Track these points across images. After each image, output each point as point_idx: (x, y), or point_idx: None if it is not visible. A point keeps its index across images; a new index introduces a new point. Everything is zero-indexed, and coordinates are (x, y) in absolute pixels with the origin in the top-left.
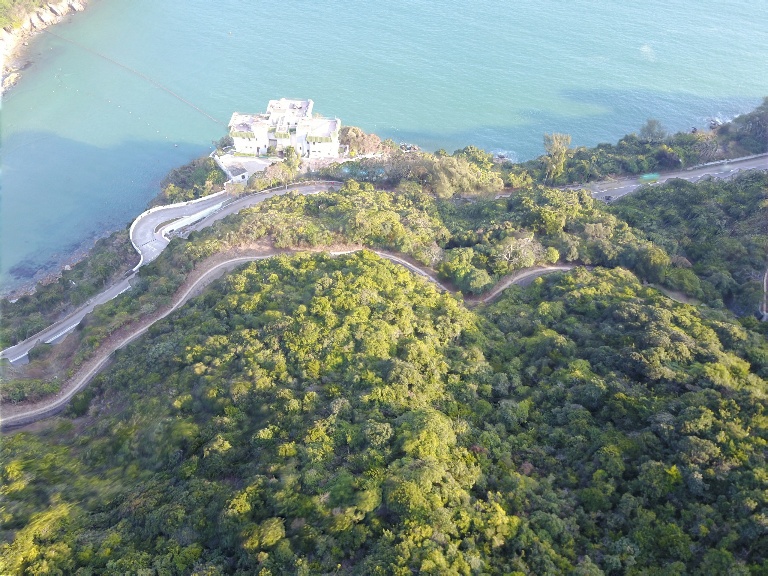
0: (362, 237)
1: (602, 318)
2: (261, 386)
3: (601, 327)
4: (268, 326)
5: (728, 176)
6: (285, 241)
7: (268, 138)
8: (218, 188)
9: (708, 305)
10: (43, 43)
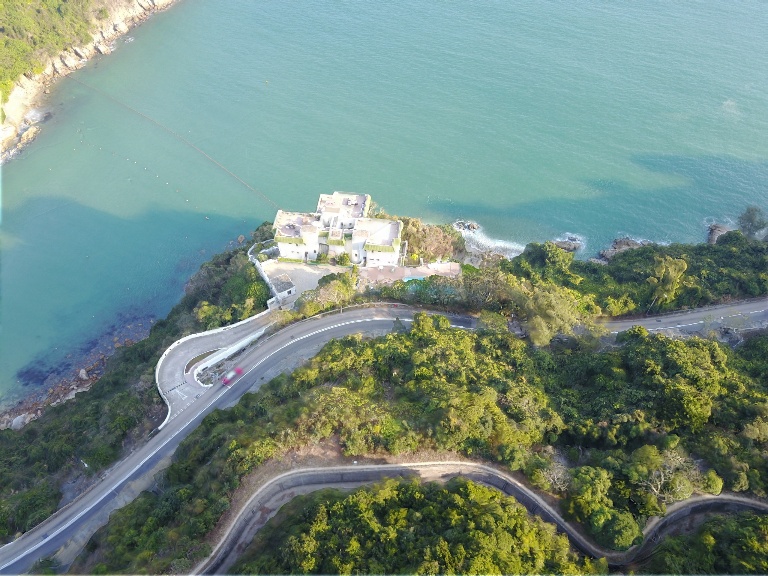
0: (456, 441)
1: None
2: None
3: None
4: None
5: None
6: (358, 447)
7: (318, 242)
8: (260, 306)
9: None
10: (66, 91)
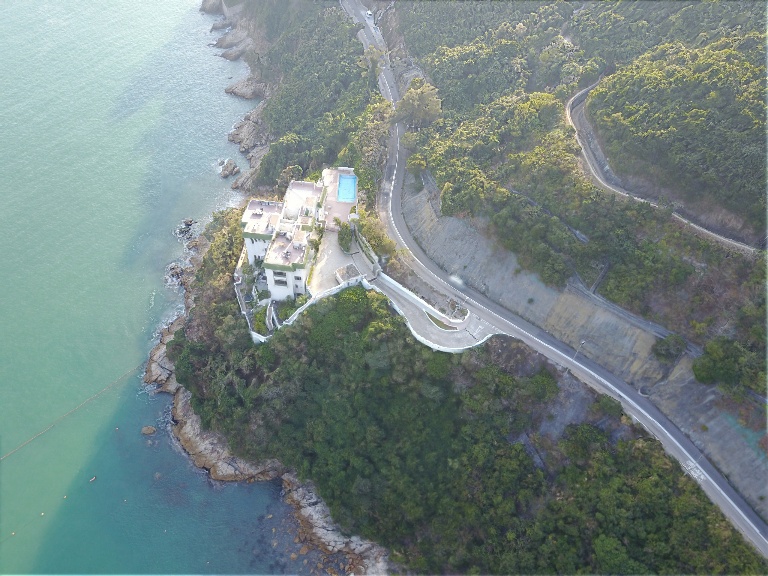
0: None
1: (647, 8)
2: None
3: (659, 6)
4: None
5: (412, 0)
6: None
7: None
8: None
9: (576, 8)
10: None
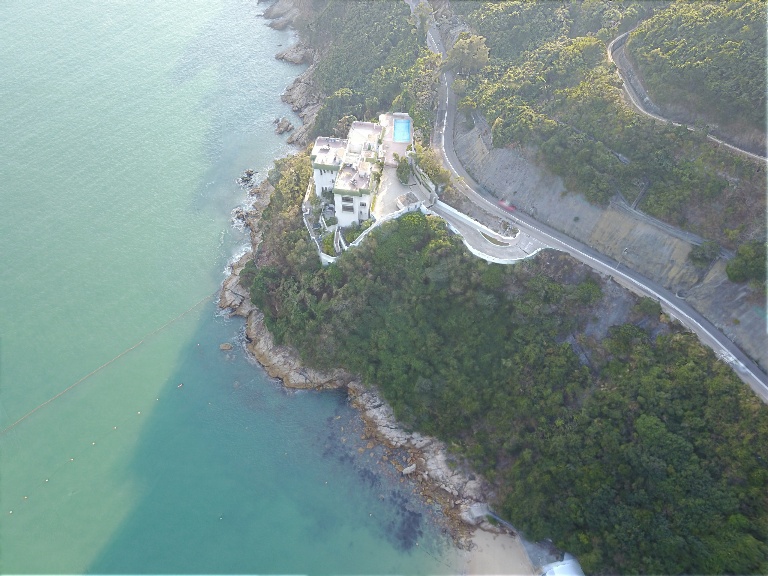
0: None
1: None
2: None
3: None
4: (765, 21)
5: None
6: None
7: None
8: None
9: None
10: None
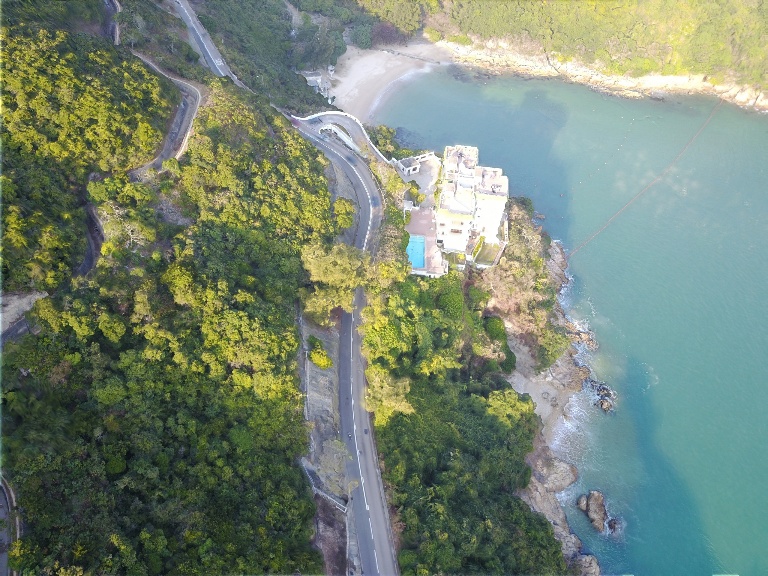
0: None
1: None
2: (1, 36)
3: None
4: None
5: None
6: None
7: None
8: None
9: None
10: (699, 103)
